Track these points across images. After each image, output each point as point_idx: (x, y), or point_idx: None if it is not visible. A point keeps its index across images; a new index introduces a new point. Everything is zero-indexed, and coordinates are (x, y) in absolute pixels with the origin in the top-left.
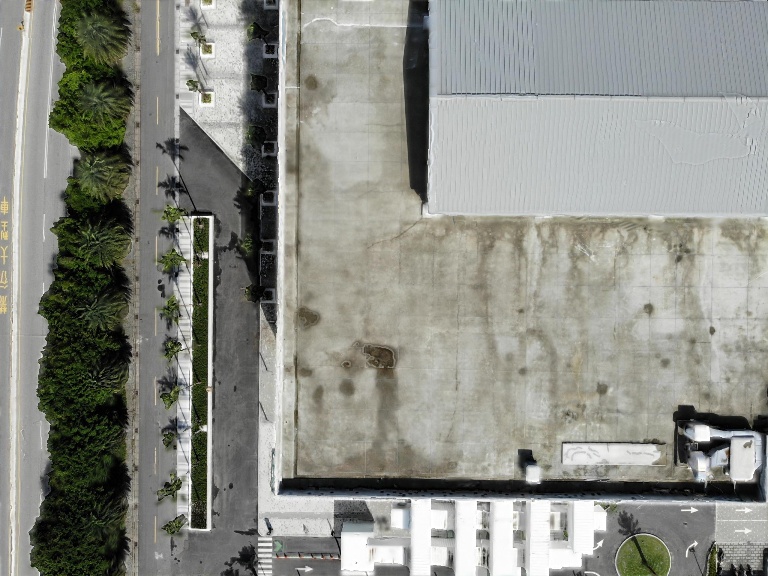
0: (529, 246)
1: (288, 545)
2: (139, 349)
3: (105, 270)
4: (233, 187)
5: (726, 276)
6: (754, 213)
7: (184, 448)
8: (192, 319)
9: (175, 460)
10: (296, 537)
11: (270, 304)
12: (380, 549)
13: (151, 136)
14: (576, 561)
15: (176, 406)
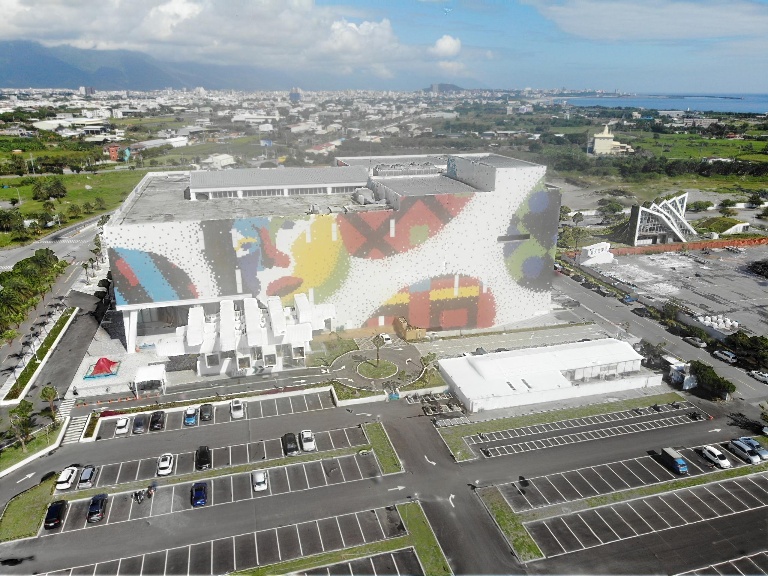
0: (235, 201)
1: (89, 400)
2: (3, 347)
3: (2, 309)
4: (95, 301)
5: (317, 199)
6: (315, 182)
7: (16, 375)
8: (50, 331)
9: (5, 380)
10: (98, 396)
11: (107, 323)
12: (167, 339)
13: (51, 296)
14: (307, 326)
15: (19, 361)
